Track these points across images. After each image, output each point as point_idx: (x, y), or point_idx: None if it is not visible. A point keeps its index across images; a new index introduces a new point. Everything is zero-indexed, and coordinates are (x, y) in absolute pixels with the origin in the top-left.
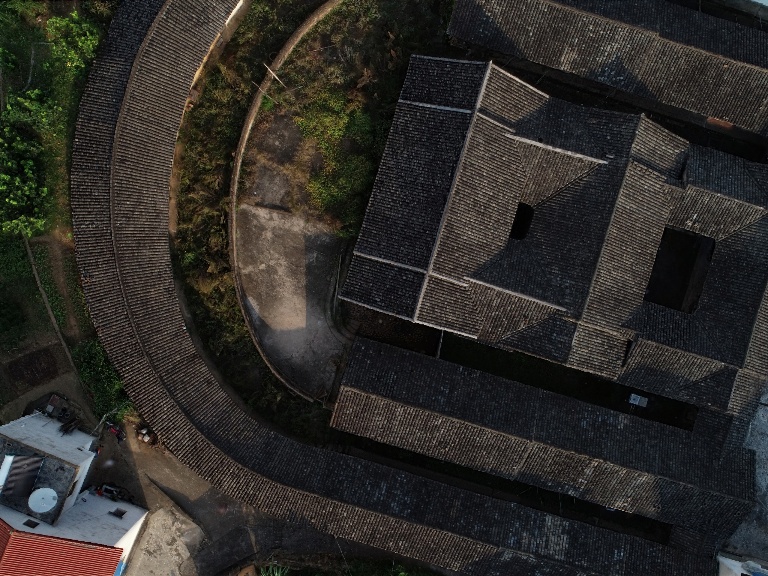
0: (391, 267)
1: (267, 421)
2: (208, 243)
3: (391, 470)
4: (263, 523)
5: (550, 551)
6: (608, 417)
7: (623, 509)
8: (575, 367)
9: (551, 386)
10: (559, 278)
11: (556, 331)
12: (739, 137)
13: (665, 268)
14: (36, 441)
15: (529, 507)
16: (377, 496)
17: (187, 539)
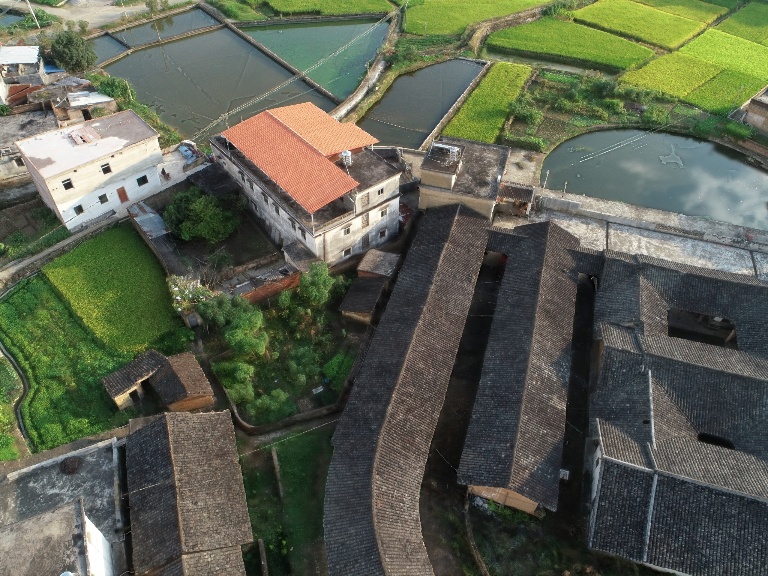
0: None
1: None
2: None
3: None
4: None
5: None
6: None
7: None
8: None
9: None
10: (763, 408)
11: None
12: None
13: None
14: None
15: None
16: None
17: None
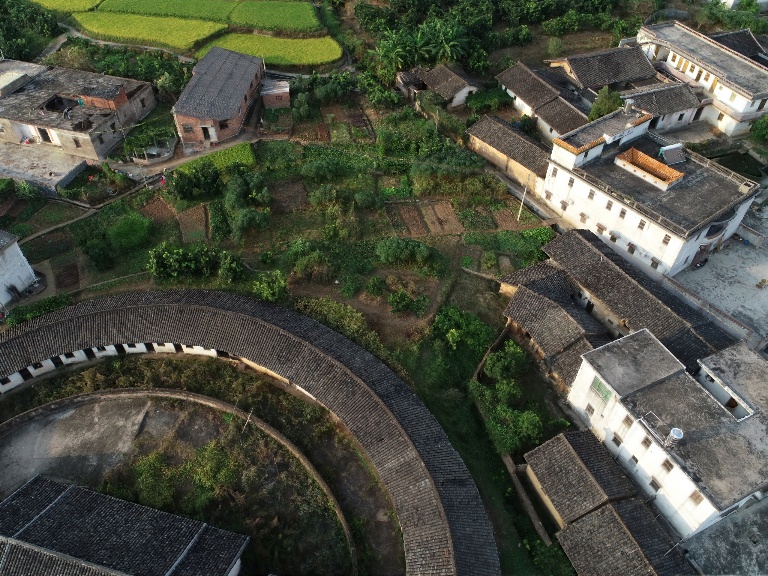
0: None
1: None
2: None
3: None
4: None
5: None
6: None
7: None
8: None
9: None
10: None
11: None
12: None
13: None
14: (1, 266)
15: None
16: None
17: None
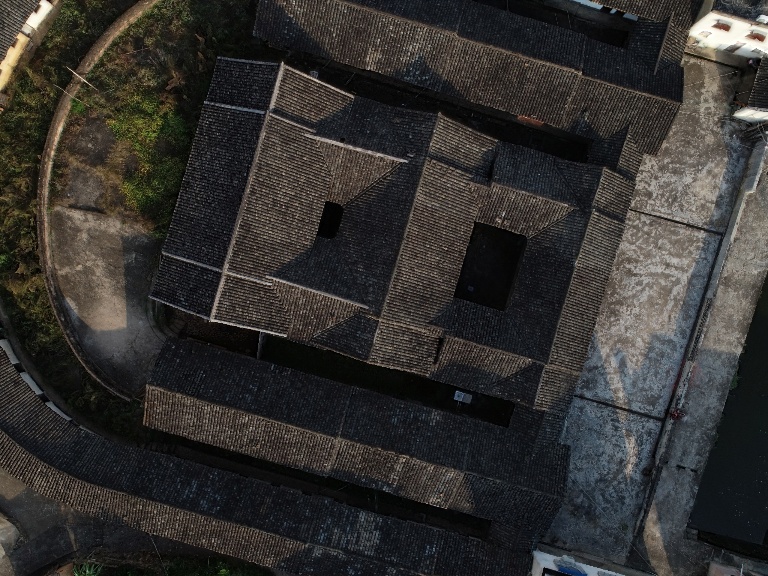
0: (195, 267)
1: (89, 420)
2: (20, 245)
3: (204, 468)
4: (83, 521)
5: (360, 547)
6: (420, 414)
7: (438, 505)
8: (379, 364)
9: (376, 384)
10: (364, 276)
11: (360, 329)
12: (561, 135)
13: (490, 266)
14: None
15: (344, 504)
16: (187, 494)
17: (2, 538)
